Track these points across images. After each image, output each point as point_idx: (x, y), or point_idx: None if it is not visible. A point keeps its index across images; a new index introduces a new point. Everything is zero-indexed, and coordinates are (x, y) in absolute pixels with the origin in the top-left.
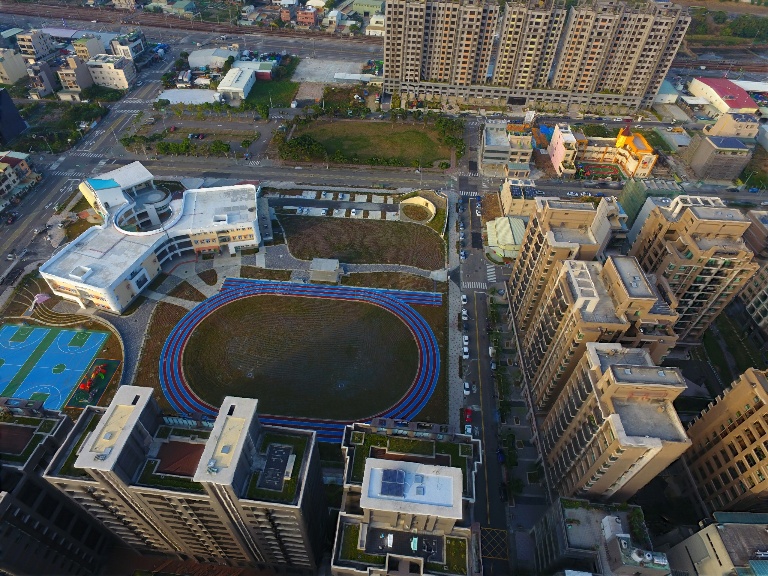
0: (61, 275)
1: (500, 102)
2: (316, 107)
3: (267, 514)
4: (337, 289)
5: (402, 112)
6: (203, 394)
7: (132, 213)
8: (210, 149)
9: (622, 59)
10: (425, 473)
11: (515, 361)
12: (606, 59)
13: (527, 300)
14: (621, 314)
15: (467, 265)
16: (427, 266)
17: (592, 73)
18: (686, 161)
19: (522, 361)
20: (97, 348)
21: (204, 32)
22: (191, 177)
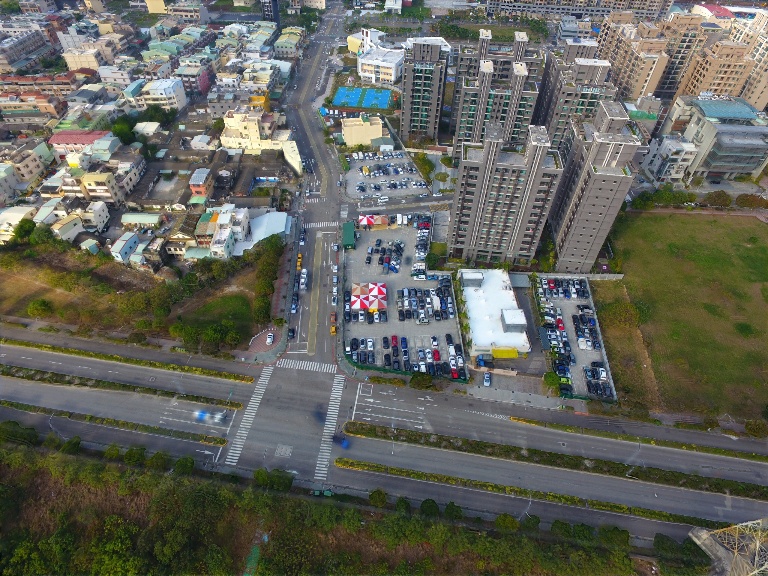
0: None
1: None
2: (452, 15)
3: (529, 68)
4: None
5: (506, 17)
6: None
7: None
8: (400, 31)
9: None
10: (585, 41)
11: None
12: None
13: None
14: None
15: None
16: None
17: None
18: None
19: None
20: (389, 94)
21: None
22: None
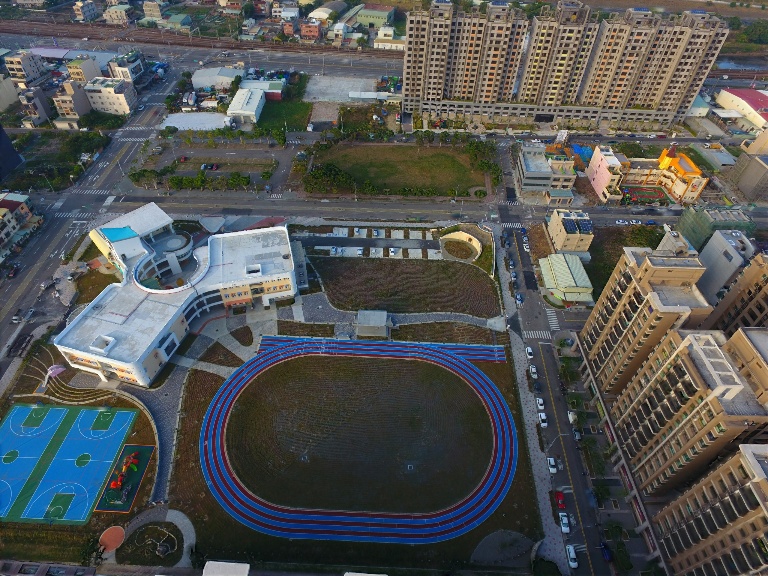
0: (80, 347)
1: (527, 120)
2: (336, 131)
3: None
4: (388, 345)
5: (428, 135)
6: (254, 486)
7: (151, 264)
8: (228, 183)
9: (655, 73)
10: None
11: (599, 428)
12: (639, 74)
13: (616, 363)
14: (766, 401)
15: (525, 310)
16: (482, 313)
17: (624, 88)
18: (732, 181)
19: (614, 433)
20: (125, 431)
21: (204, 48)
22: (209, 215)
